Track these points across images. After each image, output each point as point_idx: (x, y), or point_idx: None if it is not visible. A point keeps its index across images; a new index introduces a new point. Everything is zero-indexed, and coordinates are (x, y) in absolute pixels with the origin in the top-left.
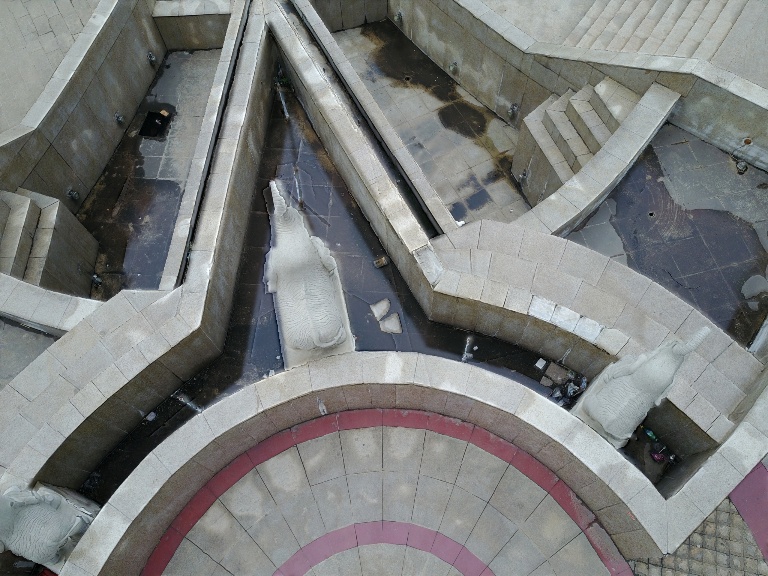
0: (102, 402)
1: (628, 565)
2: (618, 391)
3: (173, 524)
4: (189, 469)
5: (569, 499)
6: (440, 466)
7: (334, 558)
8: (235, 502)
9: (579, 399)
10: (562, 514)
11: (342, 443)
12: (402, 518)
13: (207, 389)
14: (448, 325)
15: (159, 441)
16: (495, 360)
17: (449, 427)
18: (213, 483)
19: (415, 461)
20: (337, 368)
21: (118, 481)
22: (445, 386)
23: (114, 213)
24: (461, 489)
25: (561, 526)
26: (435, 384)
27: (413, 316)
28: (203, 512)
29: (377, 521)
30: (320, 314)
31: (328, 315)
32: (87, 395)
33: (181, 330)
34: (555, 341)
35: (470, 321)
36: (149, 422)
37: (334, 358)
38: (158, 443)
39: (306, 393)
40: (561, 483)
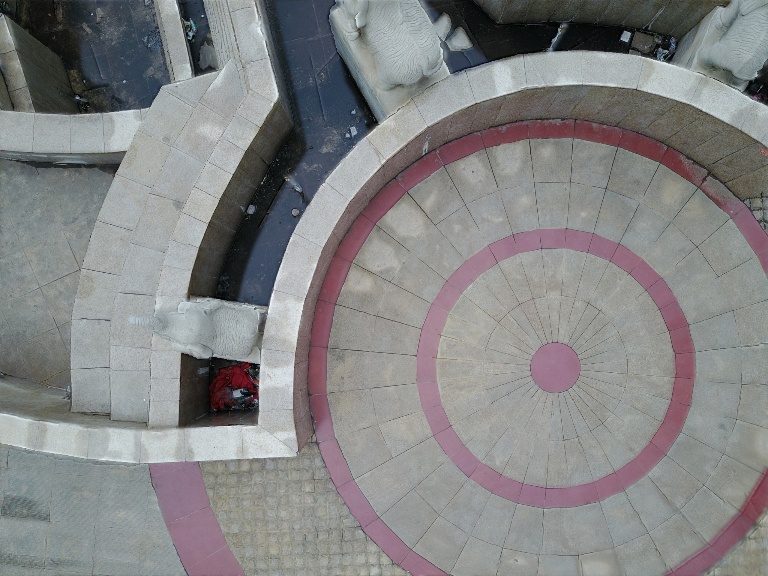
0: (216, 203)
1: (744, 204)
2: (752, 27)
3: (320, 297)
4: (329, 240)
5: (680, 163)
6: (552, 169)
7: (479, 279)
8: (370, 261)
9: (672, 62)
10: (677, 178)
11: (451, 177)
12: (530, 227)
13: (294, 166)
14: (518, 23)
15: (270, 230)
16: (577, 47)
17: (550, 129)
18: (342, 251)
19: (527, 172)
20: (444, 95)
21: (248, 277)
22: (560, 81)
23: (58, 17)
24: (578, 184)
25: (678, 189)
26: (550, 82)
27: (478, 24)
28: (344, 278)
29: (508, 236)
30: (423, 36)
31: (430, 35)
32: (197, 201)
33: (261, 106)
34: (647, 3)
35: (548, 9)
36: (251, 215)
37: (437, 86)
38: (270, 232)
39: (422, 131)
40: (670, 150)
